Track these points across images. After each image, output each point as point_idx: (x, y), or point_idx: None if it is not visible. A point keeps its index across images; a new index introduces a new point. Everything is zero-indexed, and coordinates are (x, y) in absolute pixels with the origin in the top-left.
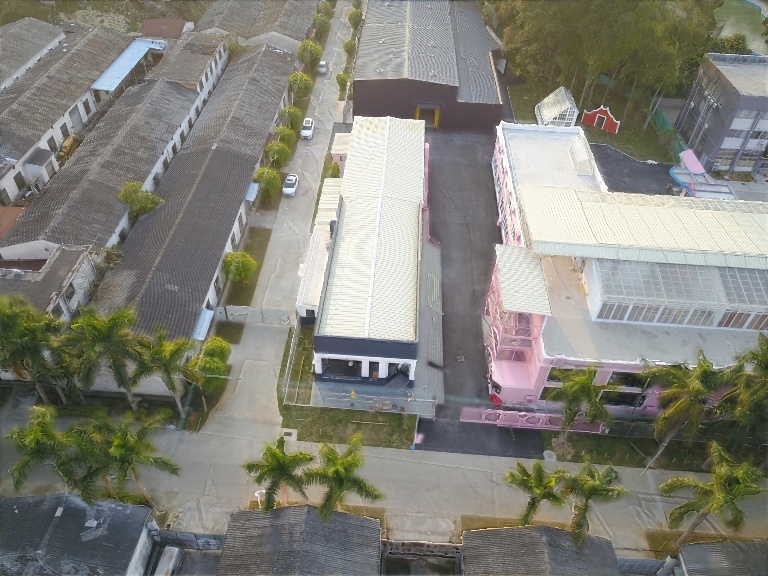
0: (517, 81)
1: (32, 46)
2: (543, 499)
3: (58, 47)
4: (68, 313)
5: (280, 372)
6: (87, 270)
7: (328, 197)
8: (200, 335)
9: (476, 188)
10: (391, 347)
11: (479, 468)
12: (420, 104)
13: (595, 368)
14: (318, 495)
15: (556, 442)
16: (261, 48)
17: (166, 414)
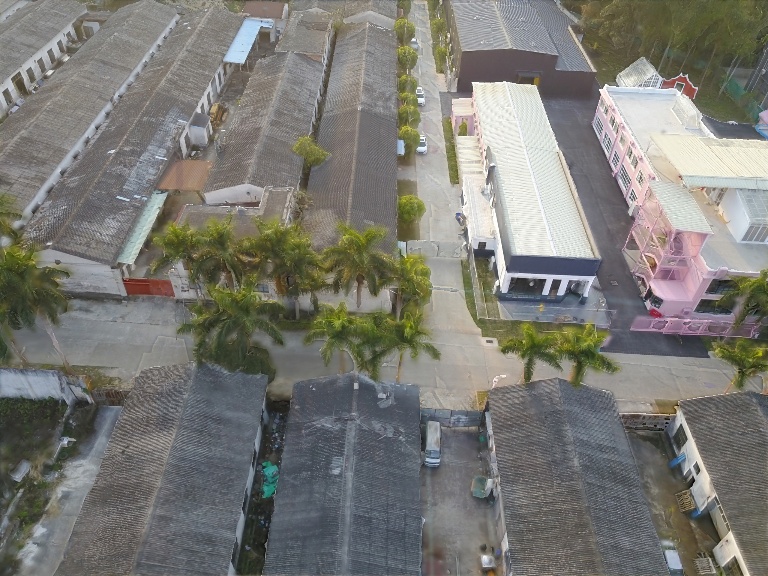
0: (594, 54)
1: (158, 25)
2: (751, 368)
3: (179, 26)
4: None
5: (465, 294)
6: (297, 207)
7: (465, 152)
8: None
9: (584, 146)
10: (577, 264)
11: (658, 365)
12: (521, 73)
13: (751, 279)
14: (569, 368)
15: None
16: (365, 25)
17: None
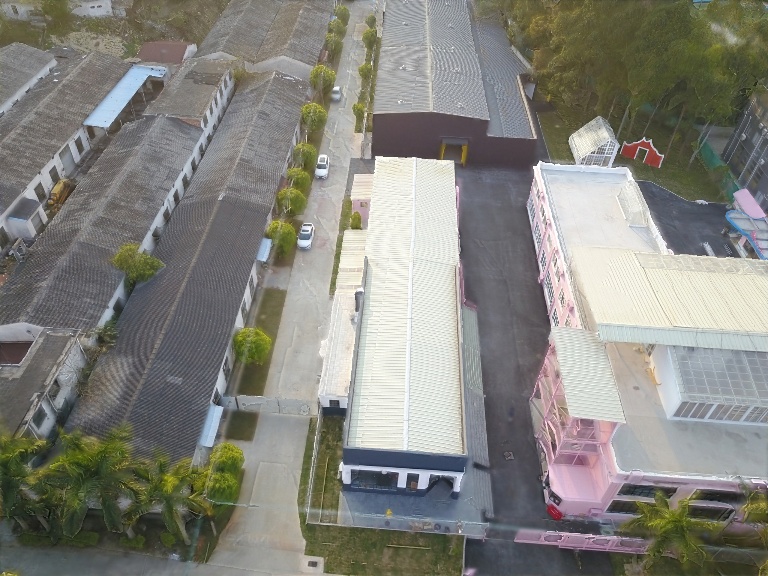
0: (547, 107)
1: (20, 76)
2: None
3: (48, 76)
4: (52, 415)
5: (301, 478)
6: (75, 361)
7: (349, 254)
8: (207, 440)
9: (511, 236)
10: (435, 460)
11: None
12: (446, 139)
13: (678, 485)
14: None
15: (630, 570)
16: (270, 75)
17: (168, 542)
